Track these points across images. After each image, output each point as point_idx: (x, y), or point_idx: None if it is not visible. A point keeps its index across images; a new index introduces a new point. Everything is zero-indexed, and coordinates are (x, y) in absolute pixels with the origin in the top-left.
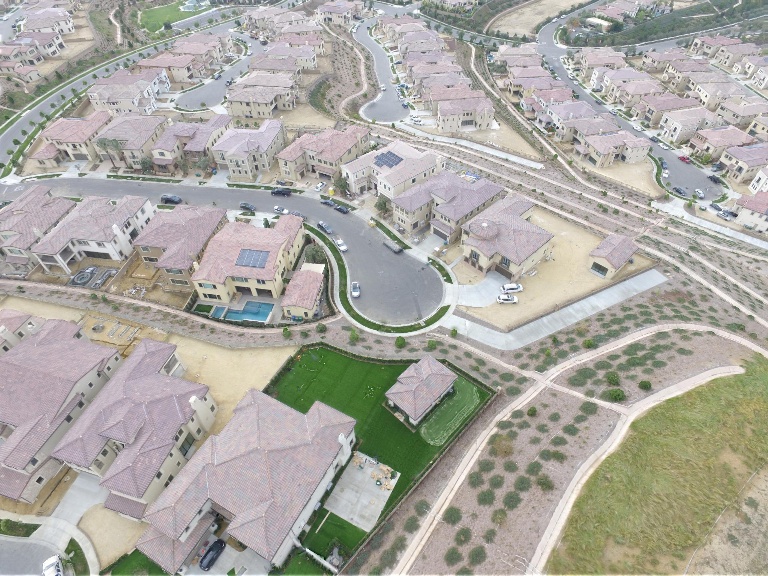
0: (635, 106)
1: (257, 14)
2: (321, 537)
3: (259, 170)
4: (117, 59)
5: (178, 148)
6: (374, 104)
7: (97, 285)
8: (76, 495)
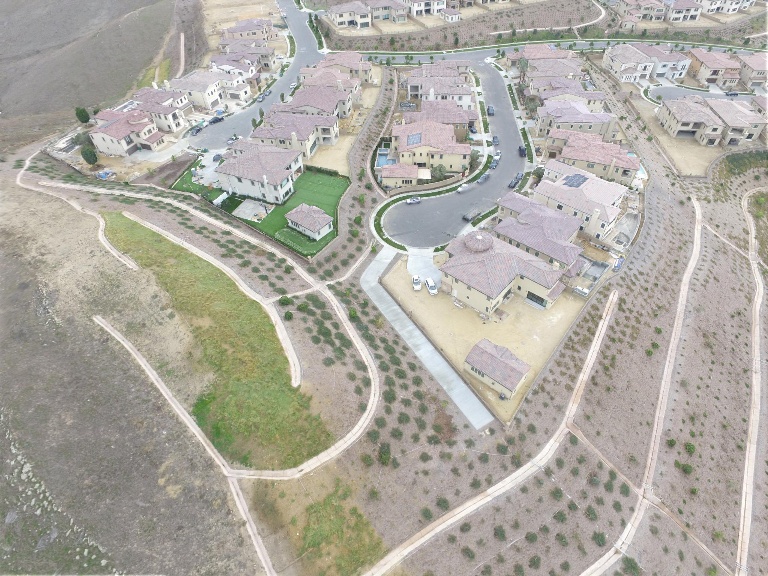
0: None
1: None
2: (233, 200)
3: None
4: (713, 46)
5: None
6: None
7: None
8: None
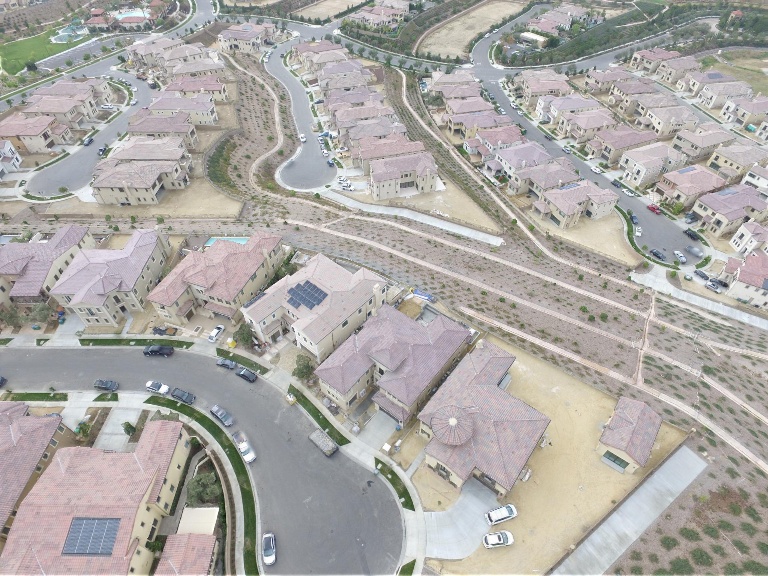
0: (590, 143)
1: (143, 48)
2: None
3: (128, 311)
4: None
5: (3, 289)
6: (293, 163)
7: None
8: None
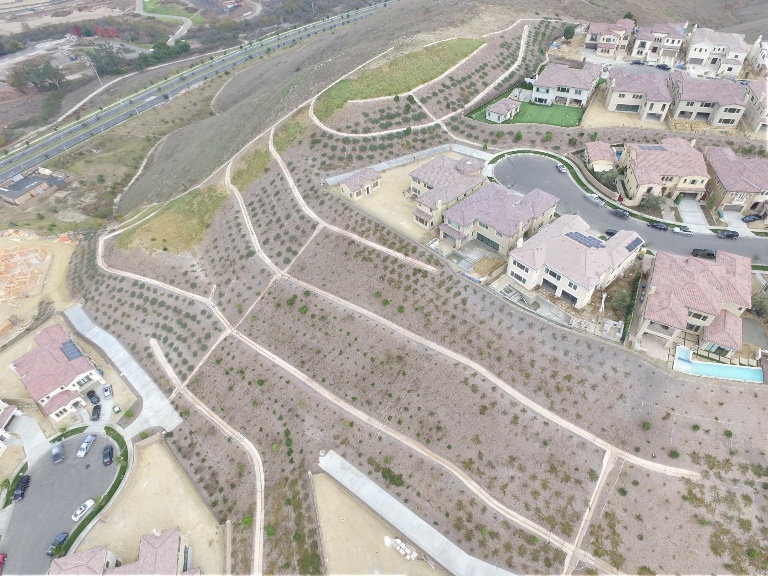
0: None
1: None
2: None
3: None
4: None
5: None
6: None
7: None
8: None
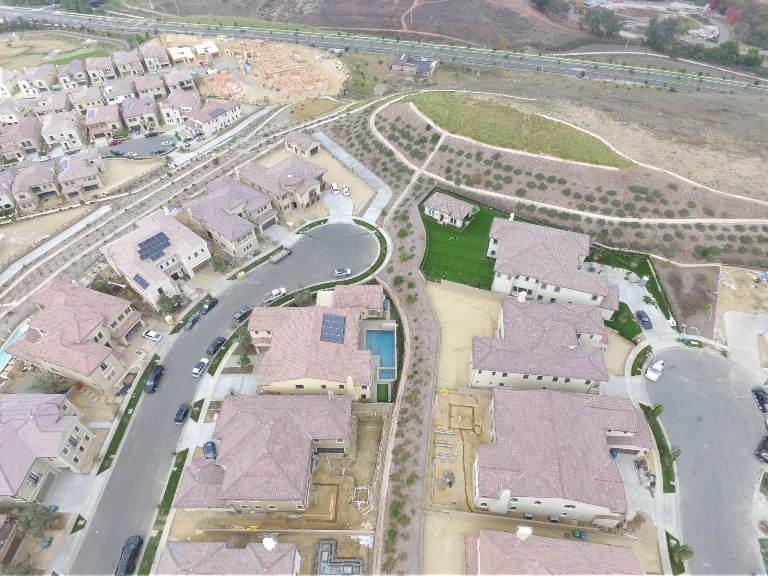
0: (6, 151)
1: None
2: None
3: None
4: None
5: None
6: None
7: (355, 571)
8: (608, 388)
